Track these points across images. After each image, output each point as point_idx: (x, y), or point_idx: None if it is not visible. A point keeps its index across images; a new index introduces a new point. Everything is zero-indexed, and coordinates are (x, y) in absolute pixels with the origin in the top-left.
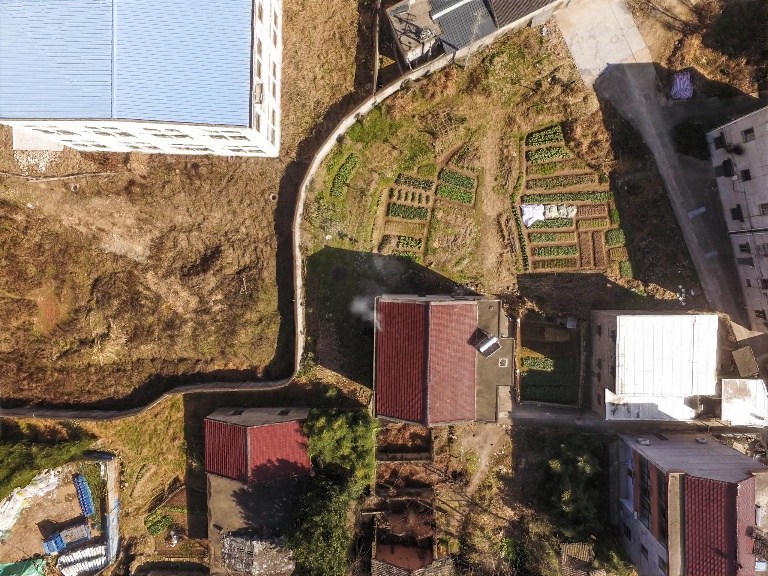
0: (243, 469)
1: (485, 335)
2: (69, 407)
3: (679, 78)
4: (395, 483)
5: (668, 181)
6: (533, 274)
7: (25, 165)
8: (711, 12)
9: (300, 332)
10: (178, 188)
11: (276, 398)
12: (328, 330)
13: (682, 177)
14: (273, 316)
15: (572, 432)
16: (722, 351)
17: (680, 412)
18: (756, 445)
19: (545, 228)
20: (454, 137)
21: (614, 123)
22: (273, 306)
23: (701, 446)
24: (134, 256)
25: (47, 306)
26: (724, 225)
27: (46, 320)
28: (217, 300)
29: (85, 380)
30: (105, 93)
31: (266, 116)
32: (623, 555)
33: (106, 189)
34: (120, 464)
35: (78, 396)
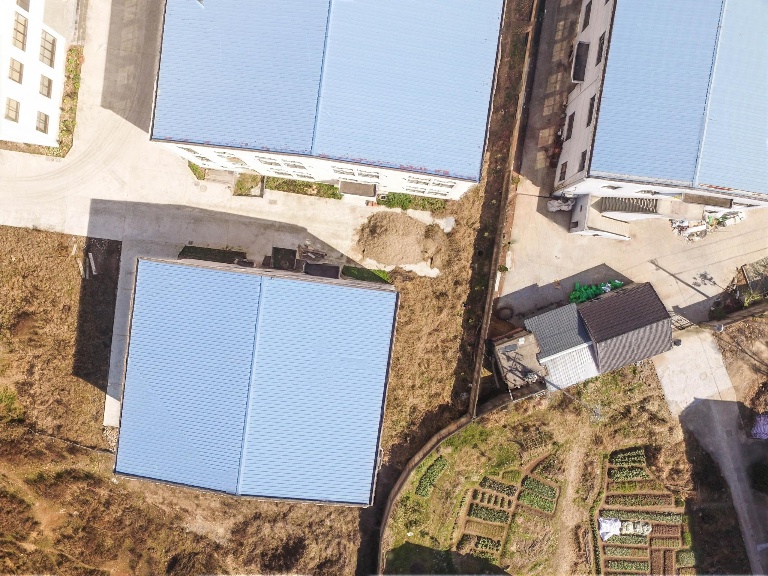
0: None
1: None
2: None
3: (761, 422)
4: None
5: (741, 514)
6: None
7: (114, 441)
8: None
9: None
10: None
11: None
12: None
13: (755, 512)
14: None
15: None
16: None
17: None
18: None
19: (620, 543)
20: (542, 450)
21: (696, 455)
22: None
23: None
24: (215, 537)
25: None
26: None
27: None
28: None
29: None
30: (232, 468)
31: None
32: None
33: None
34: None
35: None
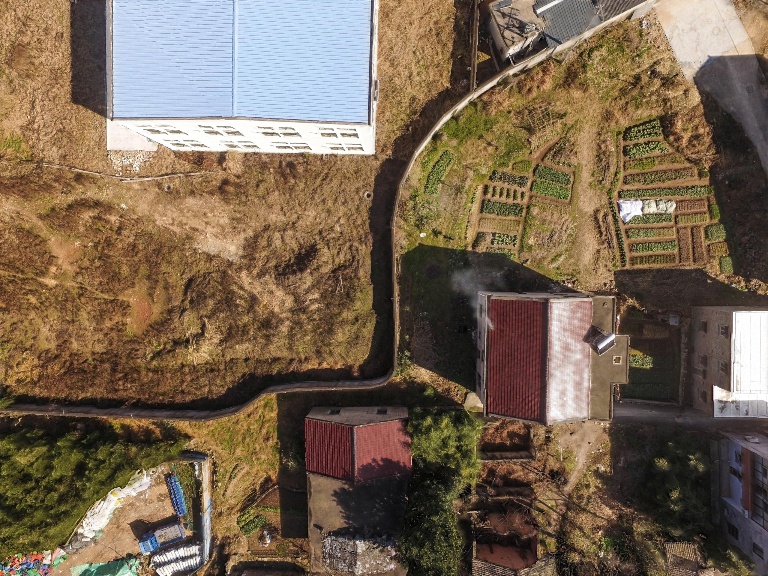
0: (349, 468)
1: (599, 332)
2: (163, 407)
3: None
4: (493, 482)
5: None
6: (631, 270)
7: (119, 165)
8: None
9: (397, 331)
10: (272, 187)
11: (370, 397)
12: (423, 328)
13: None
14: (369, 315)
15: (677, 430)
16: None
17: None
18: None
19: (643, 224)
20: (551, 132)
21: (716, 116)
22: (368, 305)
23: None
24: (227, 255)
25: (140, 306)
26: None
27: (139, 320)
28: (314, 299)
29: (179, 380)
30: (226, 91)
31: None
32: (741, 554)
33: (200, 189)
34: (212, 464)
35: (172, 396)
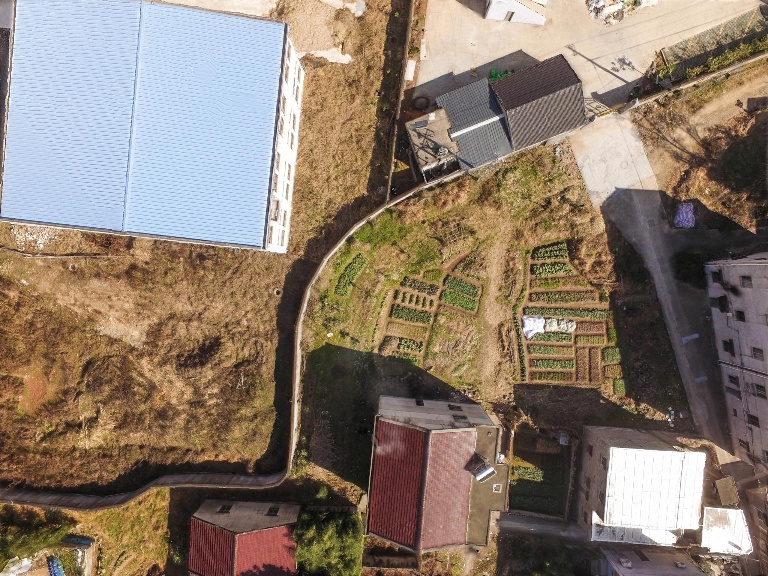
0: (228, 575)
1: (482, 460)
2: (49, 490)
3: (683, 209)
4: None
5: (665, 306)
6: (530, 385)
7: (22, 240)
8: (717, 149)
9: (295, 430)
10: (181, 275)
11: (265, 492)
12: (323, 428)
13: (679, 303)
14: (269, 412)
15: None
16: (705, 474)
17: (663, 537)
18: (731, 566)
19: (544, 341)
20: (462, 246)
21: (618, 246)
22: (269, 401)
23: (681, 572)
24: (130, 340)
25: (34, 384)
26: (715, 353)
27: (32, 398)
28: (213, 394)
29: (69, 464)
30: (117, 205)
31: (278, 223)
32: None
33: (106, 271)
34: (98, 549)
35: (60, 480)
